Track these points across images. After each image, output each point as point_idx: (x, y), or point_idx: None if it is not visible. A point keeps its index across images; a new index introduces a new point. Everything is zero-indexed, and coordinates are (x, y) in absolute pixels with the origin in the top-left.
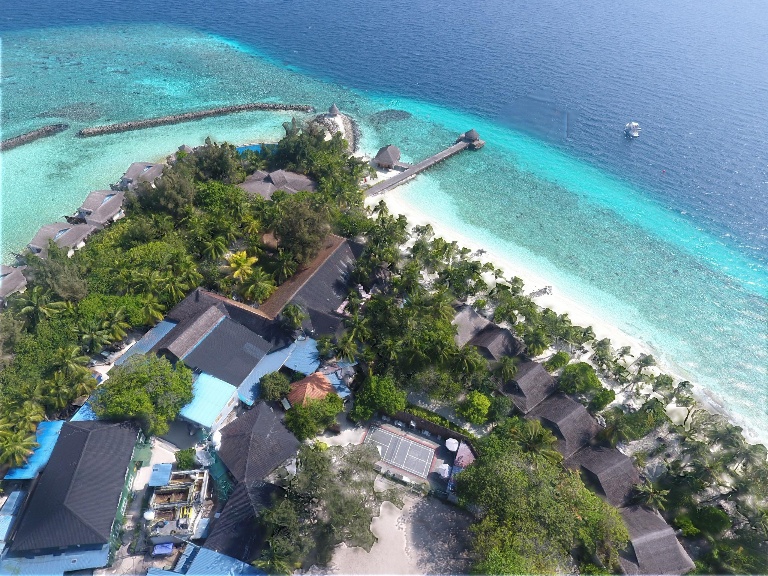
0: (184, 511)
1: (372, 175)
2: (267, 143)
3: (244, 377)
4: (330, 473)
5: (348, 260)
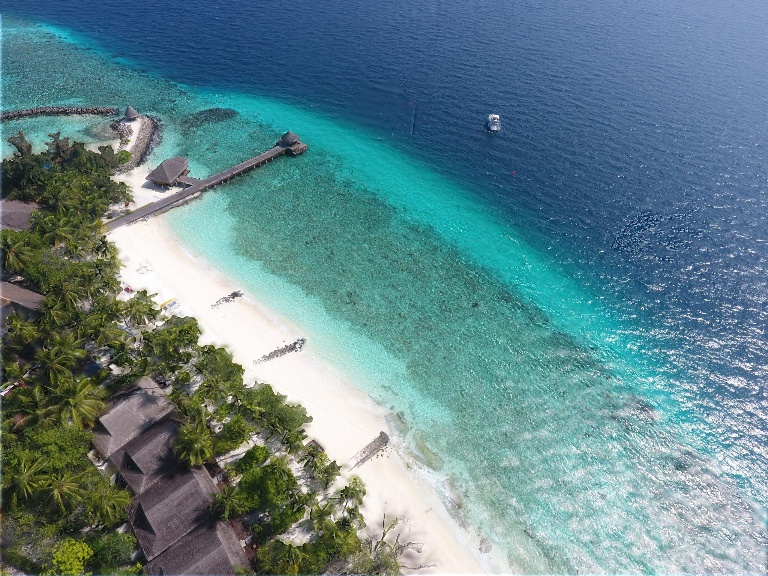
0: None
1: (124, 199)
2: None
3: None
4: None
5: (6, 330)
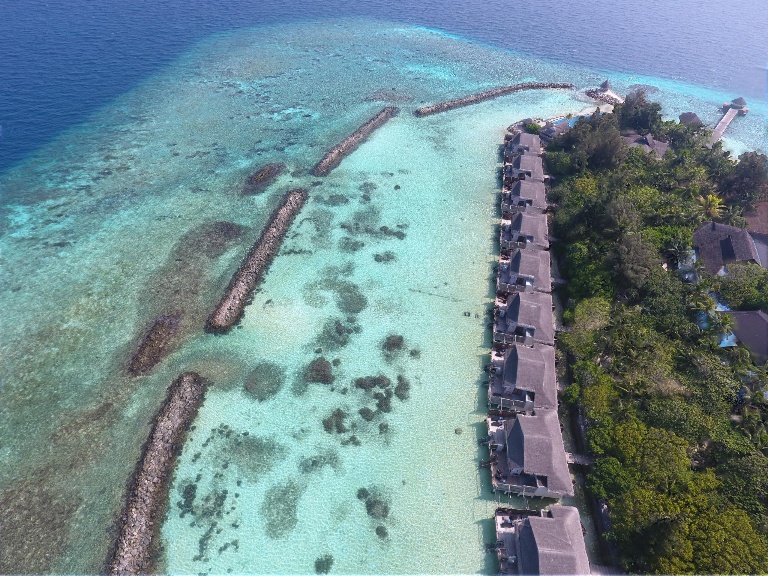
0: None
1: (708, 137)
2: (579, 115)
3: None
4: None
5: None
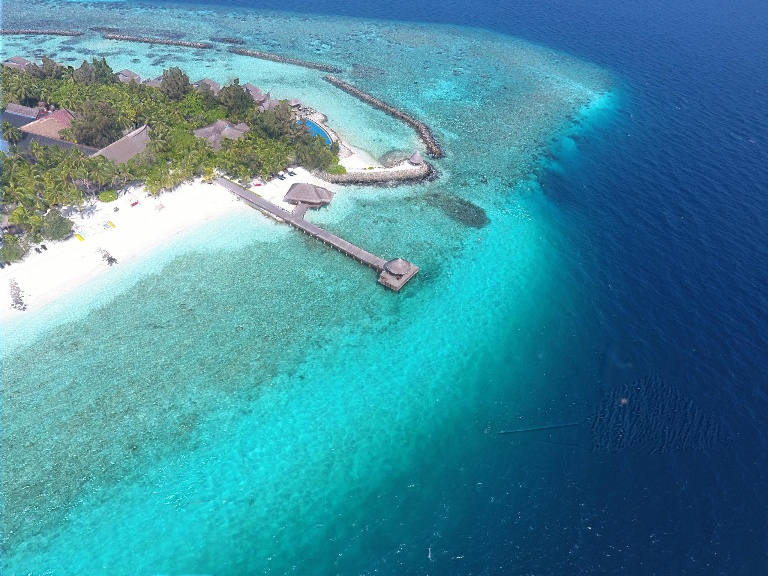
0: None
1: None
2: (328, 134)
3: None
4: None
5: None
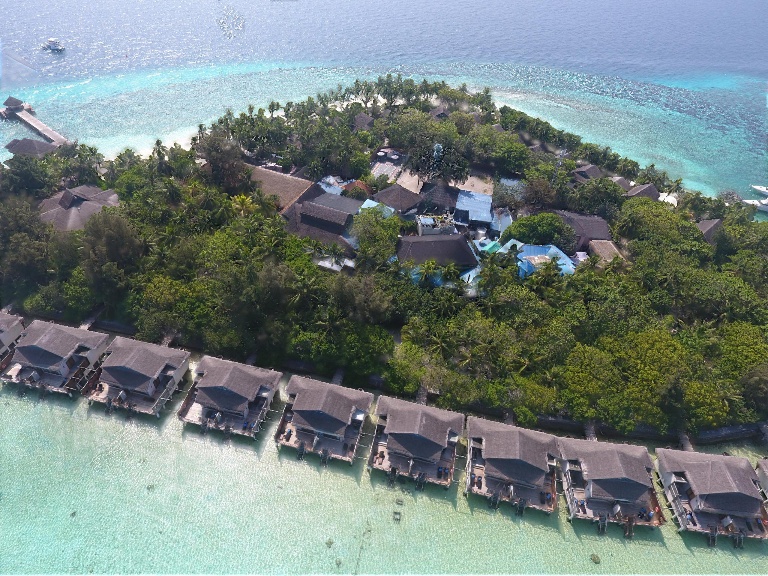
0: (440, 218)
1: None
2: None
3: (357, 200)
4: (434, 139)
5: None
